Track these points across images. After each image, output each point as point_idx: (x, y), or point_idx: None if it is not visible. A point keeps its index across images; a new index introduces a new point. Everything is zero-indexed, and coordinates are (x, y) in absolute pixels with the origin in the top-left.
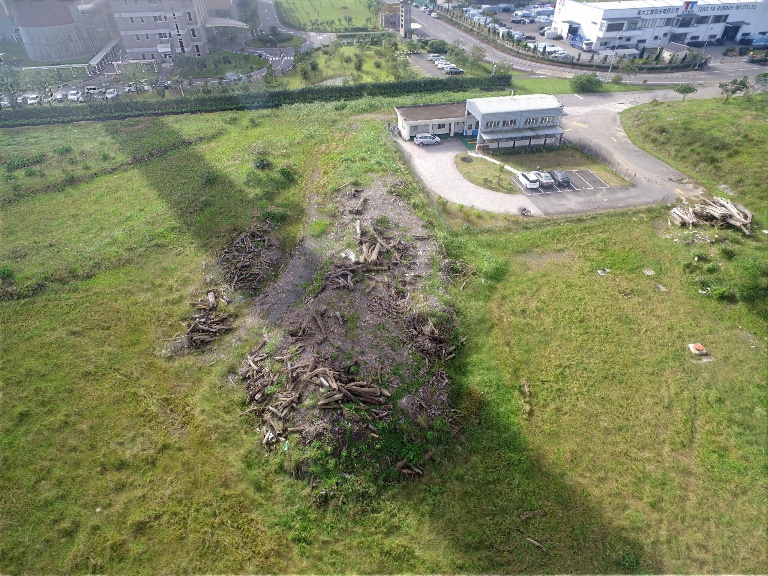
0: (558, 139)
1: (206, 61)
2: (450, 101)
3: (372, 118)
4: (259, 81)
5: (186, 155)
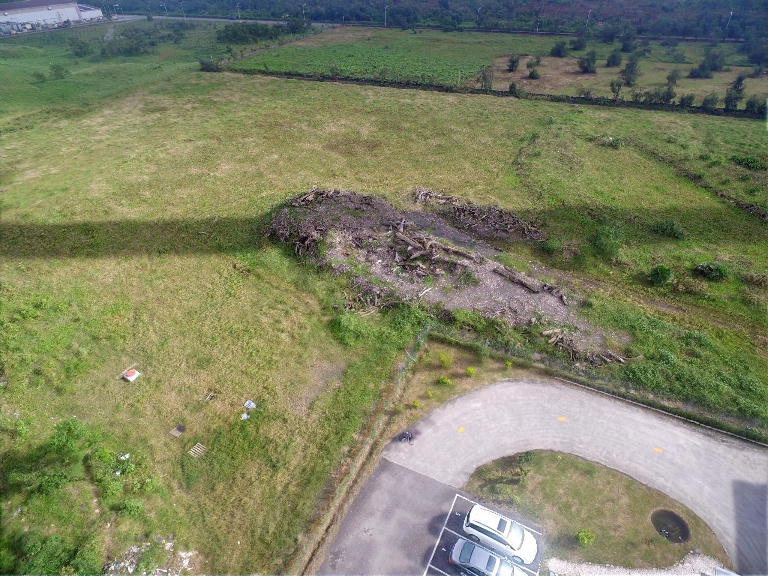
0: None
1: None
2: None
3: None
4: None
5: (764, 235)
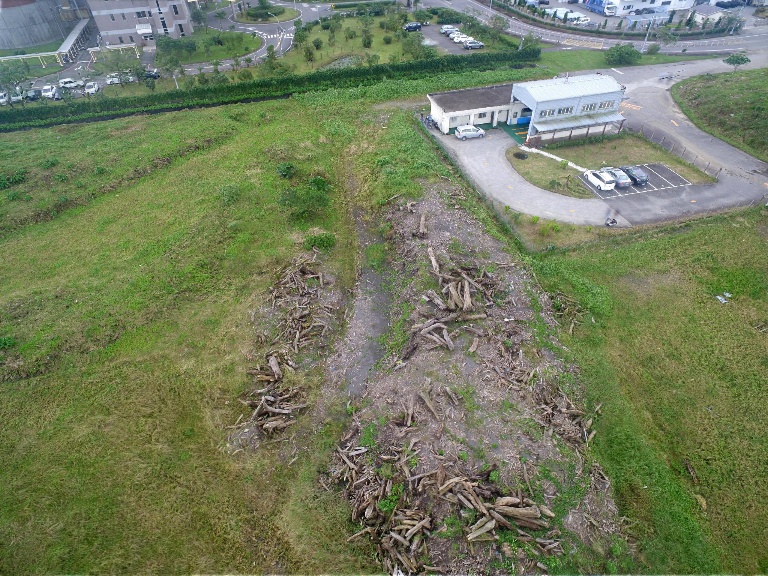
0: (613, 125)
1: (195, 43)
2: (480, 82)
3: (398, 107)
4: (264, 67)
5: (196, 164)
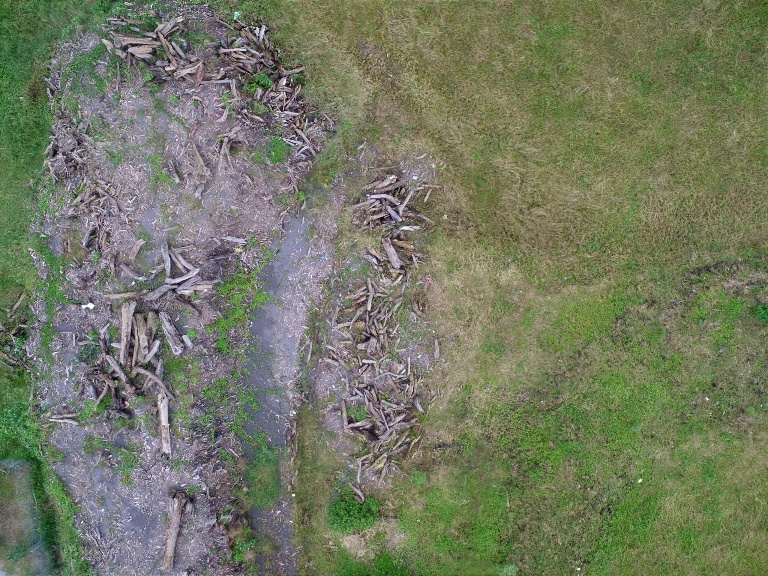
0: None
1: None
2: None
3: None
4: None
5: None
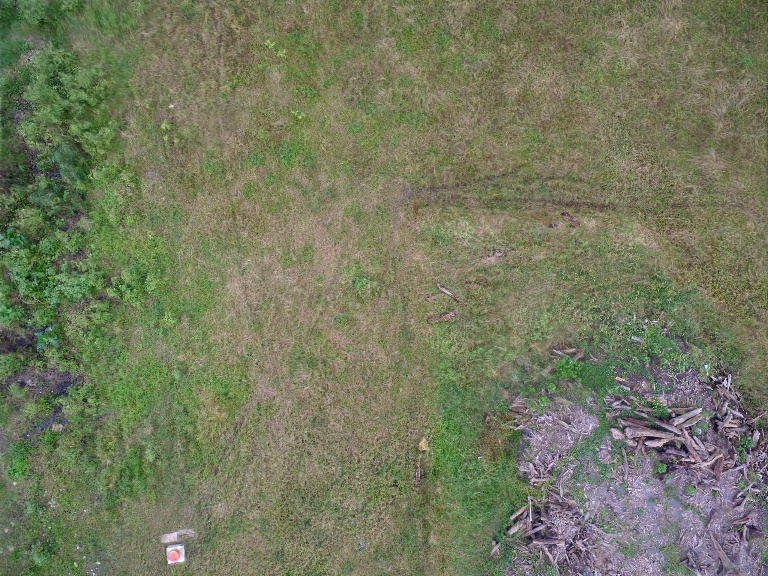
0: None
1: None
2: None
3: None
4: None
5: None
